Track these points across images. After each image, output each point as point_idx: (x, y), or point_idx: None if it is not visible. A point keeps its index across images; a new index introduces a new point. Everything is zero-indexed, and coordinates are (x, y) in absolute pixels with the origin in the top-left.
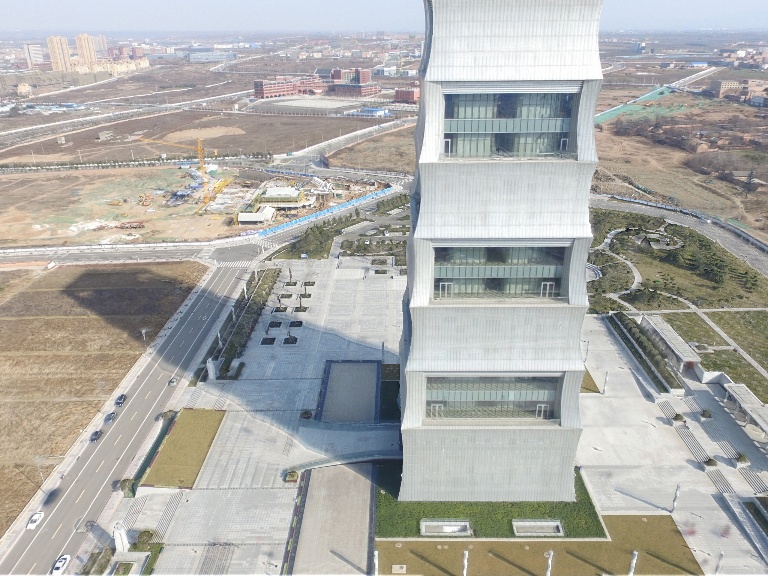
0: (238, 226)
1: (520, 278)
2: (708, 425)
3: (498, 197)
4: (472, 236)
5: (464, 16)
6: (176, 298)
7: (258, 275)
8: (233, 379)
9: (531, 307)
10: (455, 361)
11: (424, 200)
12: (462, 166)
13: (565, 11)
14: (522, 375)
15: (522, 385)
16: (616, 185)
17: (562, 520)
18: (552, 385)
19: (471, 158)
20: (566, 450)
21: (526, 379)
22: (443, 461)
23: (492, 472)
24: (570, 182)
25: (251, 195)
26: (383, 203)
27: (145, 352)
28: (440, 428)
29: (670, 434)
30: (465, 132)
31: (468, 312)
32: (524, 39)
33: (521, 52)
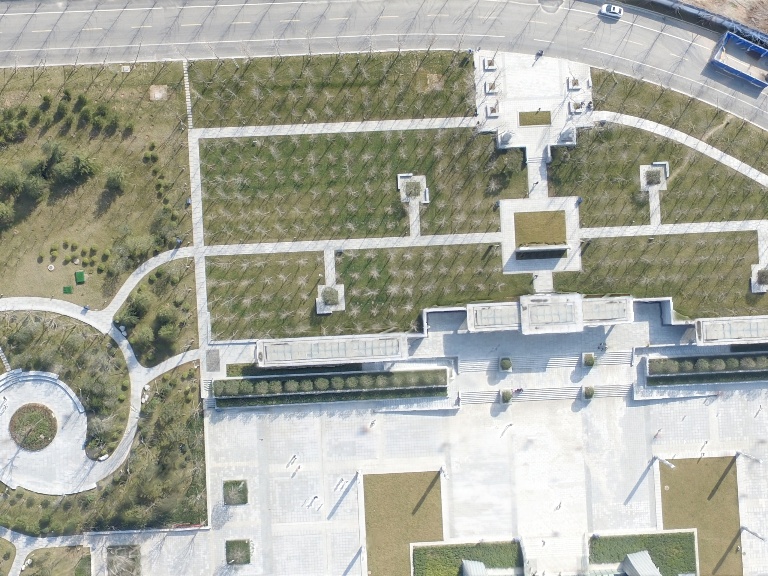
0: None
1: None
2: (517, 366)
3: None
4: None
5: None
6: None
7: None
8: None
9: None
10: None
11: None
12: None
13: None
14: None
15: None
16: None
17: (677, 573)
18: None
19: None
20: None
21: None
22: None
23: None
24: None
25: None
26: None
27: None
28: None
29: (526, 412)
30: None
31: None
32: None
33: None
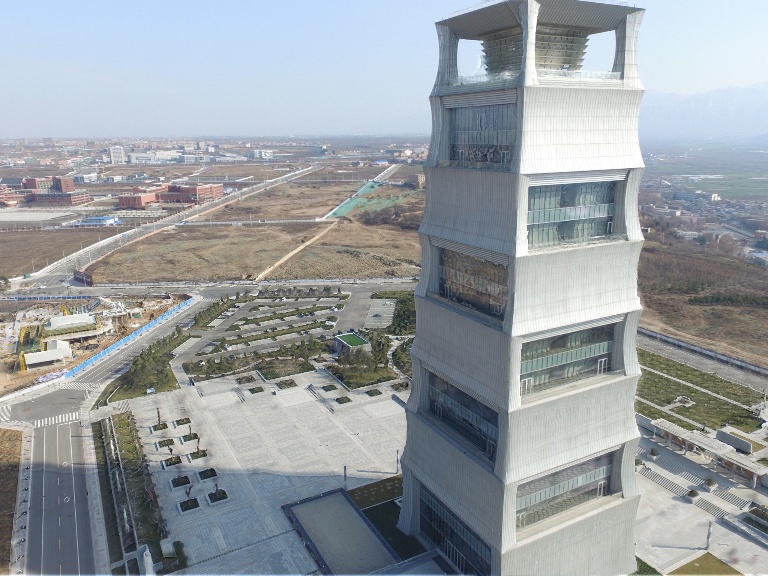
0: (26, 371)
1: (583, 360)
2: (661, 462)
3: (575, 283)
4: (558, 325)
5: (547, 111)
6: (2, 484)
7: (104, 426)
8: (181, 568)
9: (603, 386)
10: (545, 460)
11: (517, 295)
12: (549, 256)
13: (617, 108)
14: (593, 457)
15: (582, 468)
16: (406, 268)
17: None
18: (610, 459)
19: (547, 248)
20: (628, 521)
21: (593, 460)
22: (535, 575)
23: (575, 569)
24: (624, 261)
25: (12, 331)
26: (200, 315)
27: (9, 573)
28: (534, 539)
29: (641, 479)
30: (540, 223)
31: (555, 404)
32: (590, 133)
33: (589, 145)
